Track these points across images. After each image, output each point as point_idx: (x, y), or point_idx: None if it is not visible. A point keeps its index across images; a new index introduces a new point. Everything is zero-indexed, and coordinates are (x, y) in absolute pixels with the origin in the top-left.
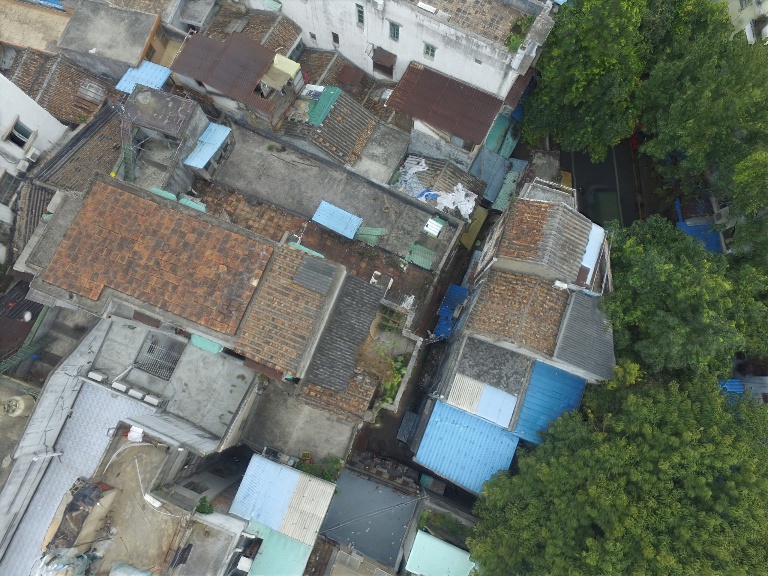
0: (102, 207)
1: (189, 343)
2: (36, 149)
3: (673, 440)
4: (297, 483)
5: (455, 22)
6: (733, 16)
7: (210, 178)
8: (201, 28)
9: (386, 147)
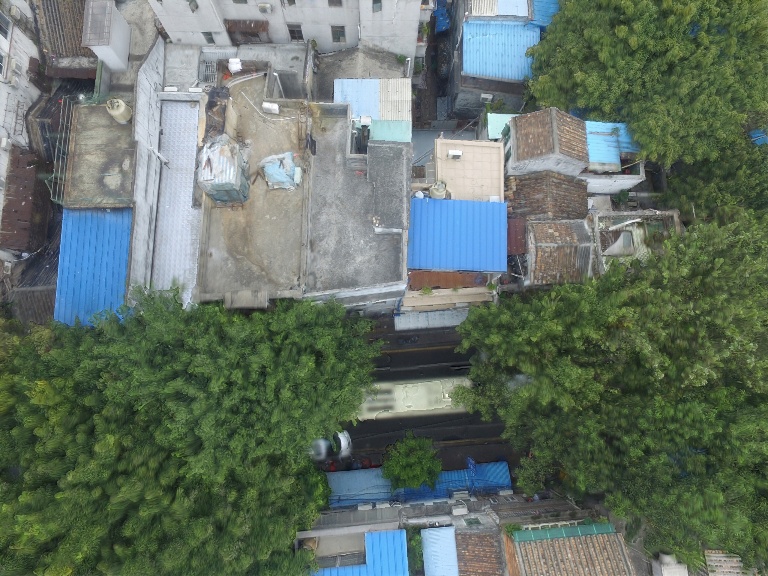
0: None
1: (239, 49)
2: None
3: None
4: (379, 85)
5: None
6: None
7: None
8: None
9: None
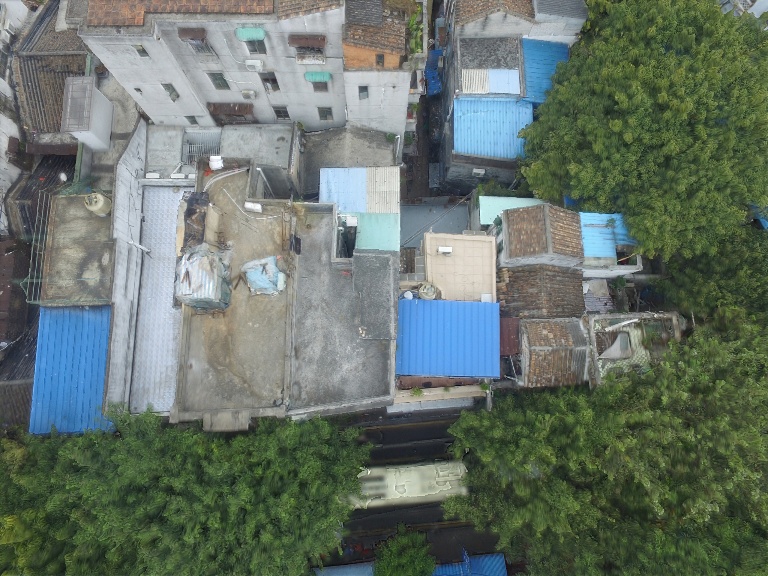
0: None
1: (223, 129)
2: (10, 21)
3: (652, 12)
4: (366, 174)
5: None
6: None
7: None
8: None
9: None
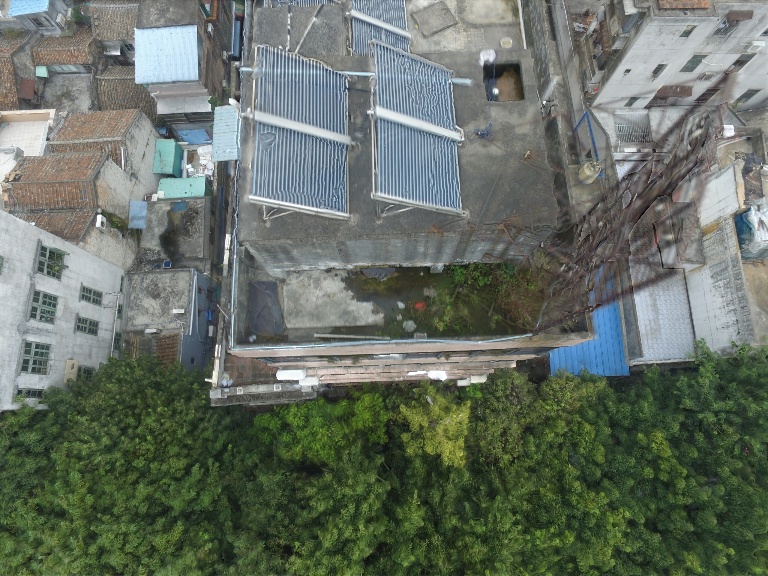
0: None
1: (651, 111)
2: None
3: None
4: None
5: None
6: None
7: None
8: None
9: None
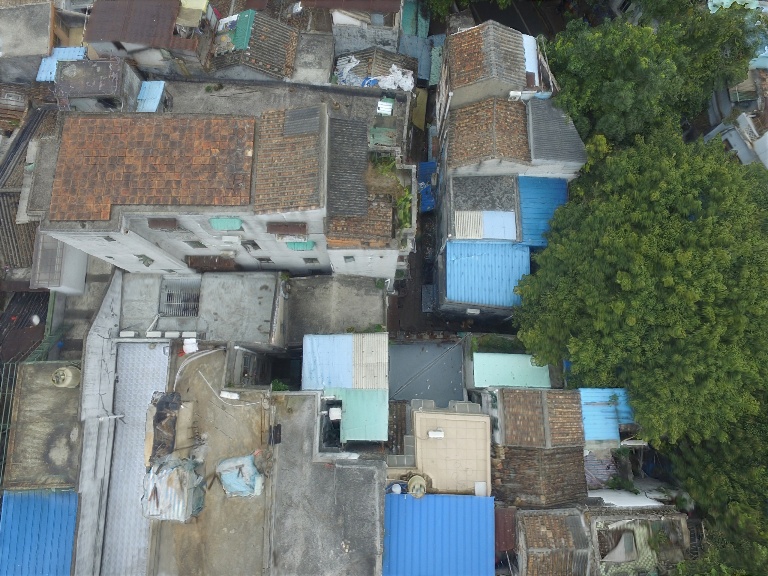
0: (79, 139)
1: (203, 277)
2: None
3: (655, 174)
4: (353, 343)
5: None
6: None
7: None
8: None
9: (315, 52)
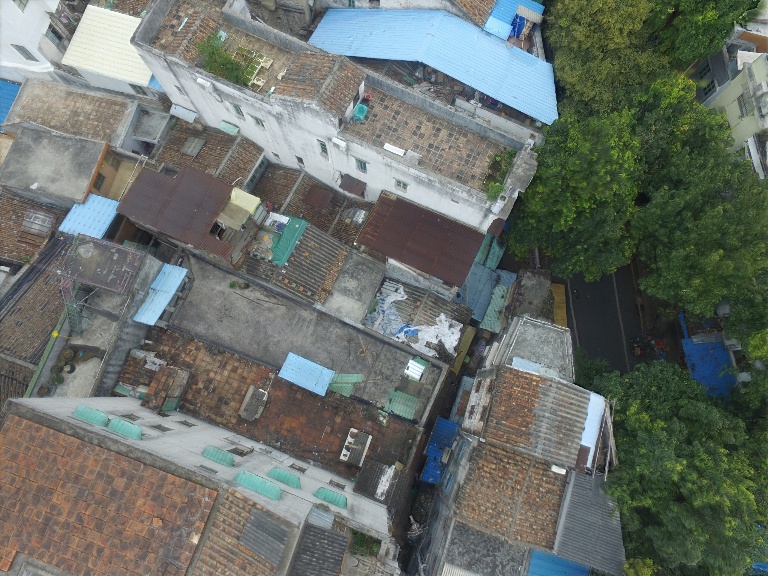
0: (15, 448)
1: None
2: None
3: None
4: None
5: (427, 160)
6: (733, 121)
7: (166, 324)
8: (156, 145)
9: (359, 279)
